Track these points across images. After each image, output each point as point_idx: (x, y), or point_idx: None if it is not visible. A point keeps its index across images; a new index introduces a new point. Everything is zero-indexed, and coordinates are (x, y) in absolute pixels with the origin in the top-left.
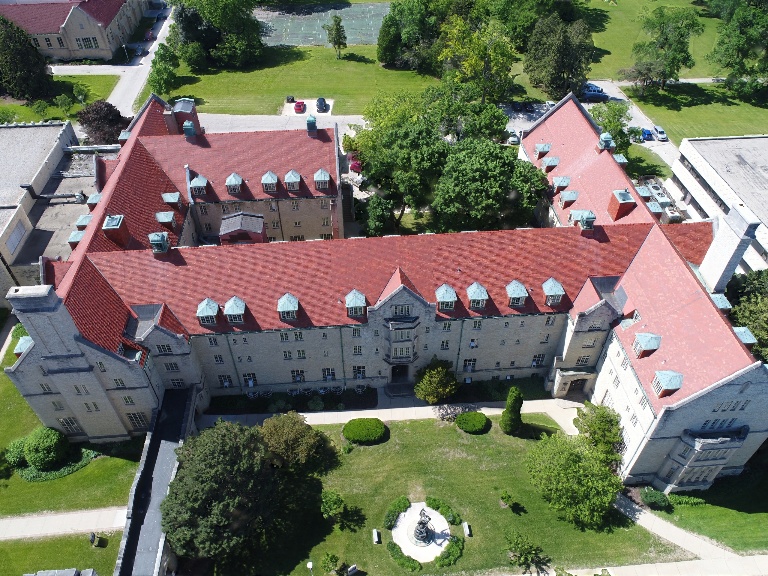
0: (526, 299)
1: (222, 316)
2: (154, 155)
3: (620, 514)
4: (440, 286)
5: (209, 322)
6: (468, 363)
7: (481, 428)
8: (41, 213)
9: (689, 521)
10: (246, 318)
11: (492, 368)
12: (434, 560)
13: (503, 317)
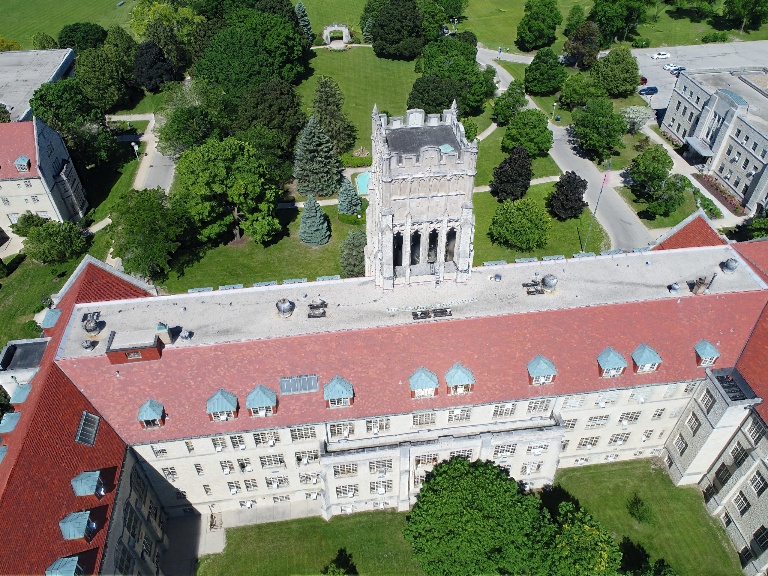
0: None
1: None
2: None
3: (86, 237)
4: None
5: None
6: None
7: None
8: None
9: (102, 216)
10: None
11: None
12: None
13: None
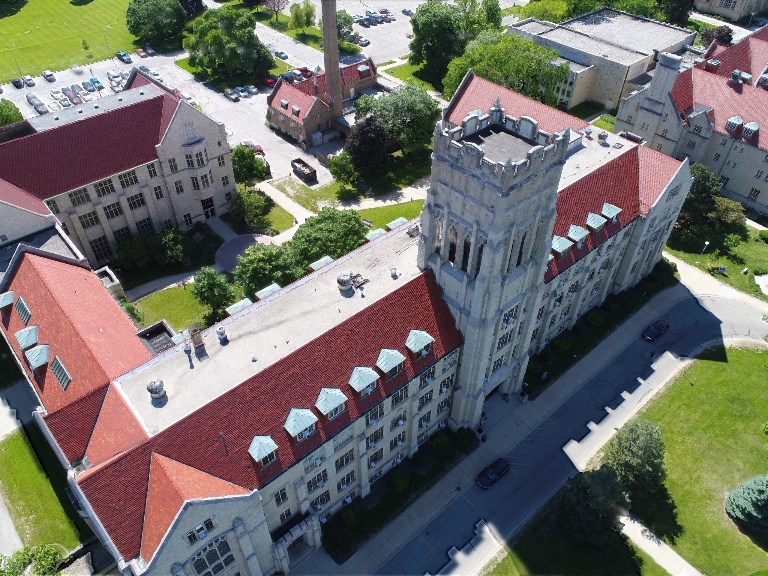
0: None
1: (741, 129)
2: (752, 51)
3: None
4: None
5: (731, 128)
6: None
7: None
8: (653, 69)
9: None
10: (754, 136)
11: None
12: None
13: None
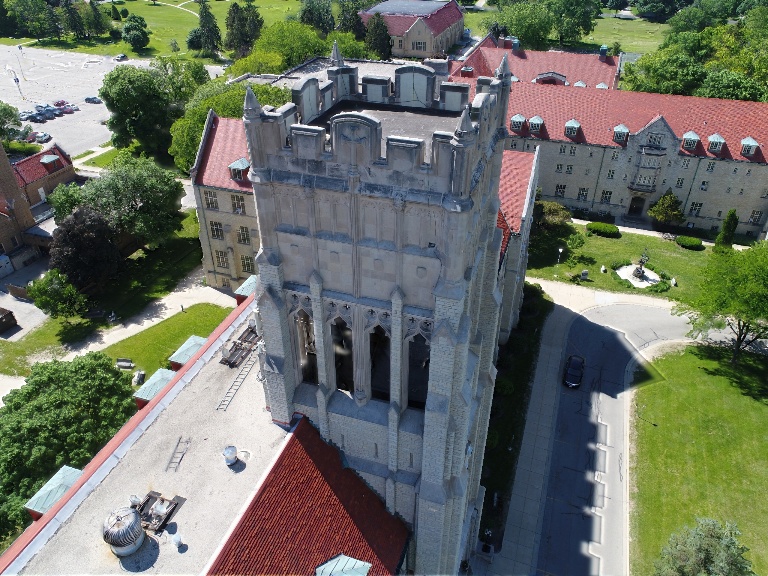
0: (756, 151)
1: (526, 126)
2: (487, 59)
3: None
4: (688, 131)
5: (517, 128)
6: (694, 208)
7: (696, 245)
8: None
9: None
10: (541, 130)
11: (714, 217)
12: (645, 287)
13: (734, 161)
